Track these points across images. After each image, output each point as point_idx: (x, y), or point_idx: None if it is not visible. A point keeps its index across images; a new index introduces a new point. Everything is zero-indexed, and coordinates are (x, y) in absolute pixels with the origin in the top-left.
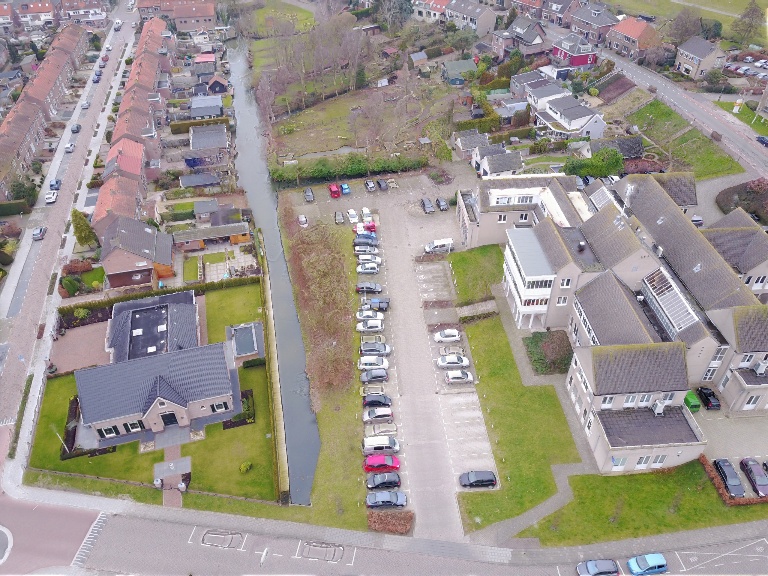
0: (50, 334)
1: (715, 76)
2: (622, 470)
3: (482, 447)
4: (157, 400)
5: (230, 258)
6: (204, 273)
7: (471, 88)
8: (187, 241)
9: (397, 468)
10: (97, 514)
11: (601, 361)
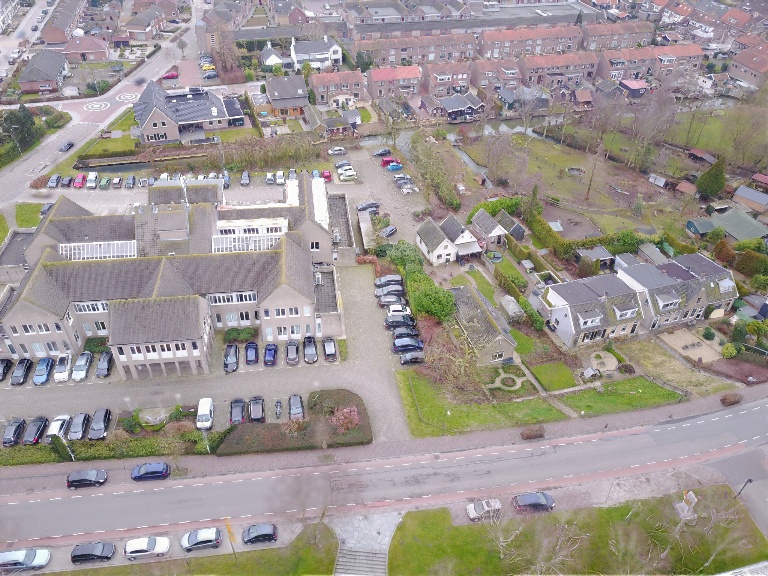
0: (223, 93)
1: None
2: None
3: None
4: None
5: None
6: None
7: None
8: None
9: (74, 185)
10: (101, 123)
11: None
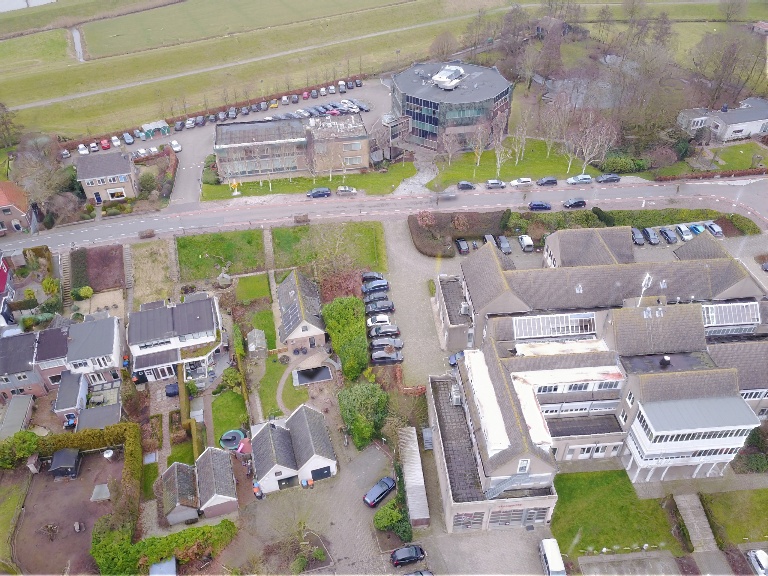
0: None
1: (153, 180)
2: None
3: None
4: None
5: None
6: None
7: None
8: None
9: None
10: None
11: None
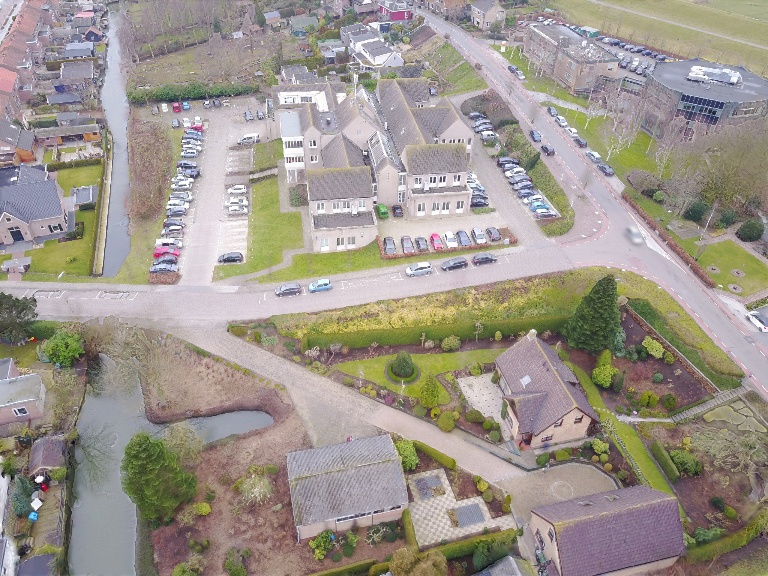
0: None
1: (496, 26)
2: (328, 250)
3: (241, 245)
4: (4, 215)
5: (82, 150)
6: (59, 158)
7: (308, 37)
8: (47, 137)
9: (177, 255)
10: None
11: (313, 179)
